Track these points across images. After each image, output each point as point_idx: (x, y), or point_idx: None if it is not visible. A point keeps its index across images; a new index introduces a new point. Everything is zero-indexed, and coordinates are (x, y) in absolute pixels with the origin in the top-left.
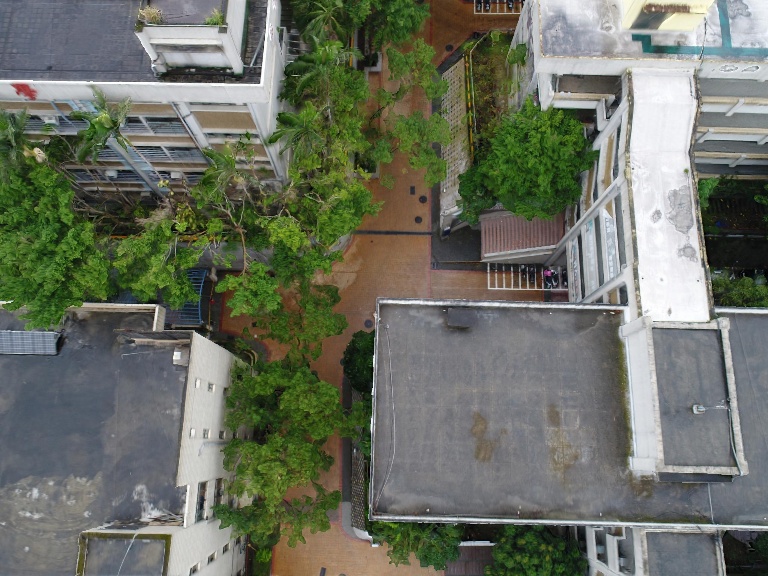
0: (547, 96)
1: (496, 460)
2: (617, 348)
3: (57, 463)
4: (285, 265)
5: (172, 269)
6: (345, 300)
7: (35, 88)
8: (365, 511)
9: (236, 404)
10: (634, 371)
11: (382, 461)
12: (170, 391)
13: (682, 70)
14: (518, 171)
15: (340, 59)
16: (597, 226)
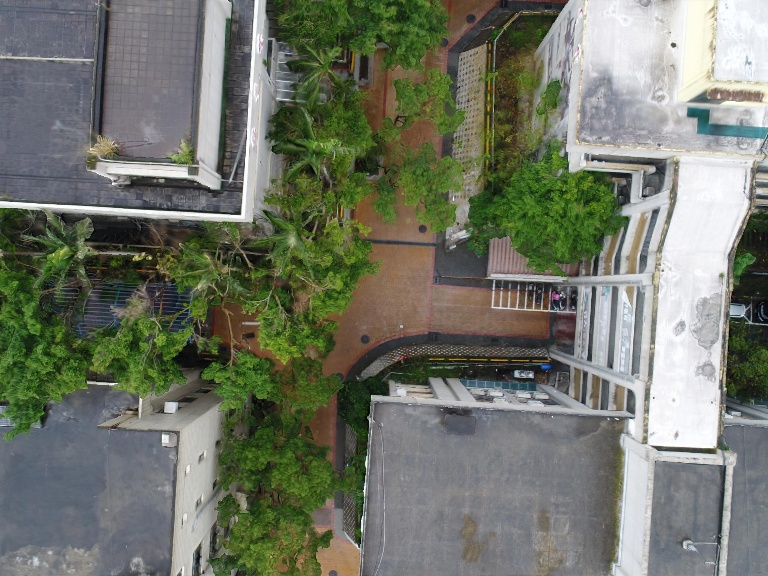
0: (577, 164)
1: (482, 561)
2: (616, 456)
3: (54, 534)
4: None
5: (153, 374)
6: None
7: None
8: (356, 529)
9: (228, 460)
10: (630, 486)
11: (371, 558)
12: (160, 468)
13: (739, 161)
14: (535, 224)
15: (337, 152)
16: (614, 294)
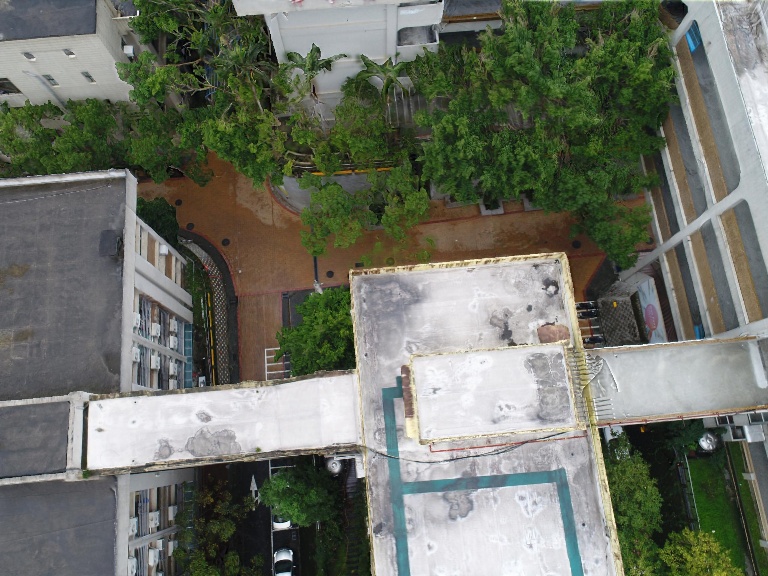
0: None
1: None
2: None
3: None
4: (199, 117)
5: (136, 2)
6: (246, 218)
7: None
8: None
9: None
10: None
11: None
12: None
13: None
14: None
15: None
16: None
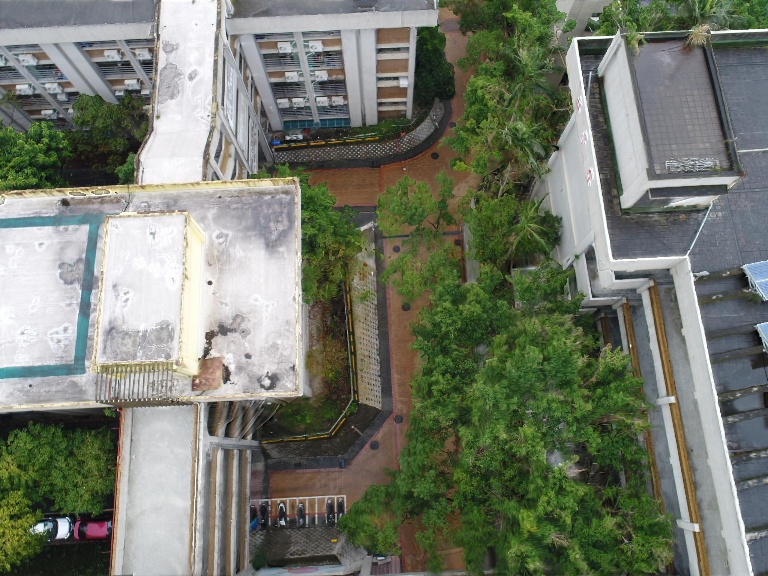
0: None
1: None
2: None
3: None
4: None
5: None
6: (459, 173)
7: None
8: None
9: None
10: None
11: None
12: None
13: None
14: None
15: None
16: None
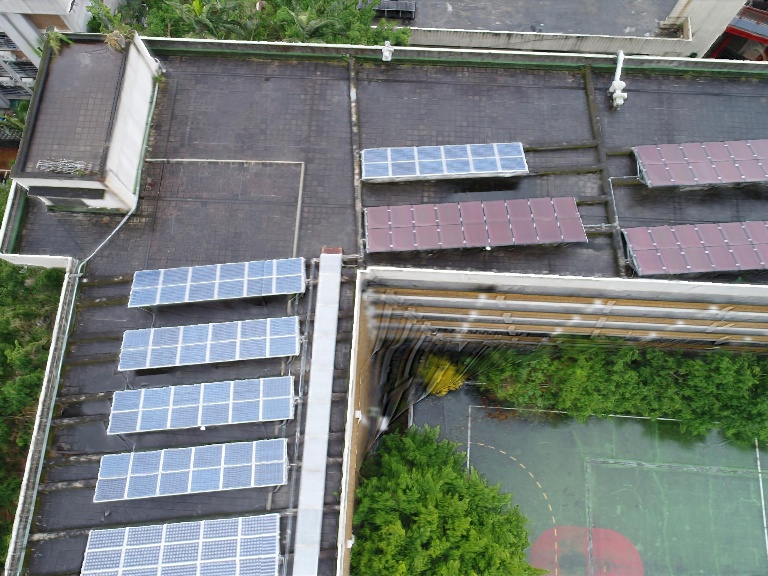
0: None
1: None
2: None
3: None
4: None
5: (212, 0)
6: None
7: (272, 49)
8: None
9: None
10: None
11: None
12: None
13: None
14: None
15: None
16: None
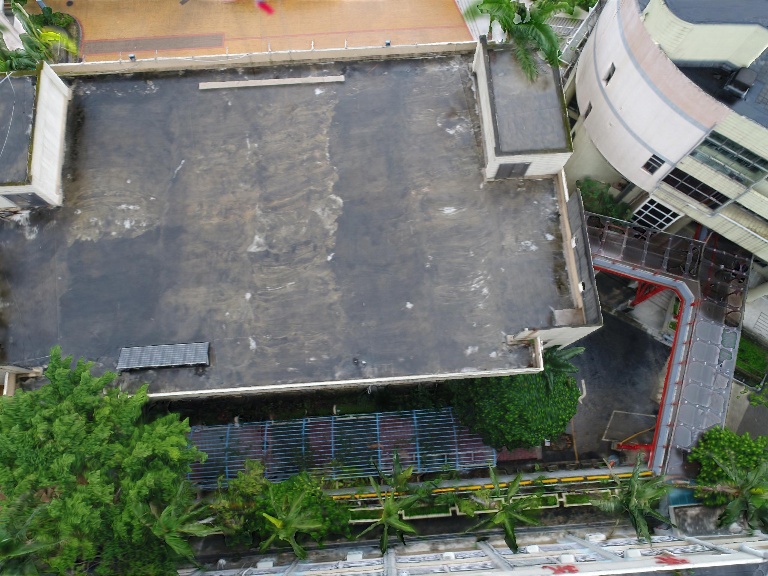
0: None
1: None
2: None
3: (110, 250)
4: None
5: None
6: None
7: None
8: None
9: None
10: None
11: None
12: (6, 324)
13: None
14: None
15: None
16: None
